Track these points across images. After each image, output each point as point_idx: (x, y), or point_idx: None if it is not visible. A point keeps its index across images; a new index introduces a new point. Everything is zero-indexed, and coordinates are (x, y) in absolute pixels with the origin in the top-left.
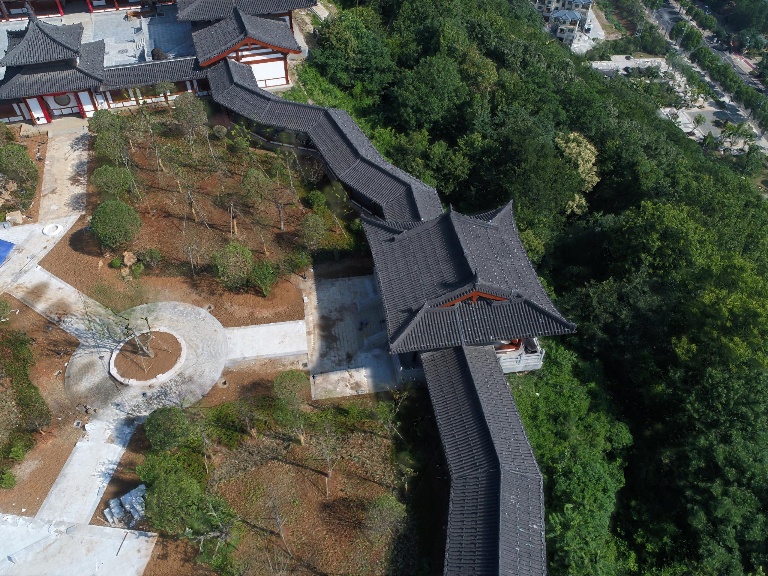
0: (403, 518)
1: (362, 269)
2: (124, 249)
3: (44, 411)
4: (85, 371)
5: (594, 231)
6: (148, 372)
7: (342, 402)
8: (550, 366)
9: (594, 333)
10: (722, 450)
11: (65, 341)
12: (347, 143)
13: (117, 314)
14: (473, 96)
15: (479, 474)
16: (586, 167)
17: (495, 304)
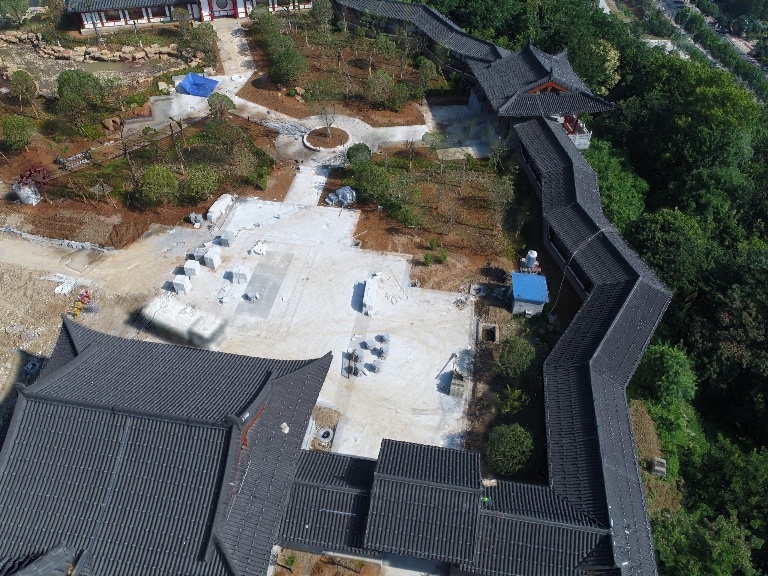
0: (512, 197)
1: (460, 101)
2: (294, 86)
3: (271, 159)
4: (288, 145)
5: (620, 88)
6: (330, 145)
7: (460, 161)
8: (594, 150)
9: (623, 129)
10: (706, 171)
11: (269, 131)
12: (444, 24)
13: (299, 119)
14: (527, 6)
15: (559, 169)
16: (611, 62)
17: (562, 94)
